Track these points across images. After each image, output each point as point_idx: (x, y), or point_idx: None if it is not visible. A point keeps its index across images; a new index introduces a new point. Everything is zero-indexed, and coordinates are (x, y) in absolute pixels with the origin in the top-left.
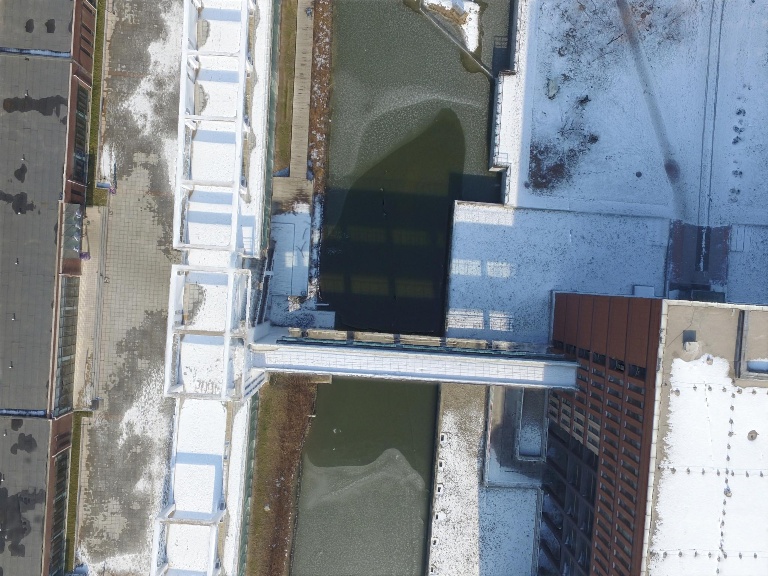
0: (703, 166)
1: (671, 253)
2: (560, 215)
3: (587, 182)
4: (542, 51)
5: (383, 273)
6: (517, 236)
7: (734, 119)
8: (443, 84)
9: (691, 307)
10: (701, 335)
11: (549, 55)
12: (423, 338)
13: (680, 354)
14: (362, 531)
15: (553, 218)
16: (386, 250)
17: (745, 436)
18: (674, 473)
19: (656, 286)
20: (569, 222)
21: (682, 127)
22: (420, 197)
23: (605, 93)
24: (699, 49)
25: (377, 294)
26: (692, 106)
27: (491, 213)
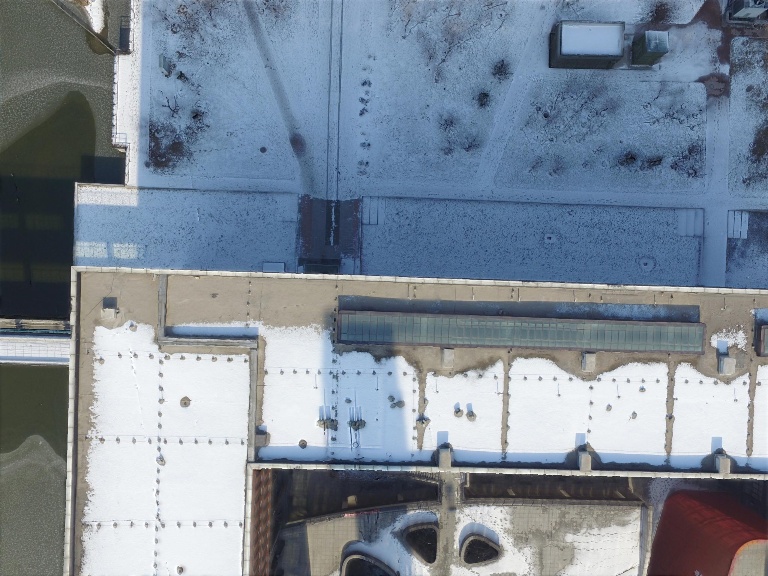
0: (330, 139)
1: (300, 228)
2: (186, 194)
3: (209, 159)
4: (157, 29)
5: (18, 259)
6: (143, 216)
7: (360, 91)
8: (70, 67)
9: (109, 273)
10: (123, 302)
11: (164, 33)
12: (40, 322)
13: (101, 322)
14: (8, 519)
15: (179, 197)
16: (20, 236)
17: (178, 403)
18: (103, 443)
19: (289, 262)
20: (196, 201)
21: (306, 100)
22: (52, 181)
23: (223, 69)
24: (321, 21)
25: (12, 280)
26: (316, 79)
27: (114, 194)
